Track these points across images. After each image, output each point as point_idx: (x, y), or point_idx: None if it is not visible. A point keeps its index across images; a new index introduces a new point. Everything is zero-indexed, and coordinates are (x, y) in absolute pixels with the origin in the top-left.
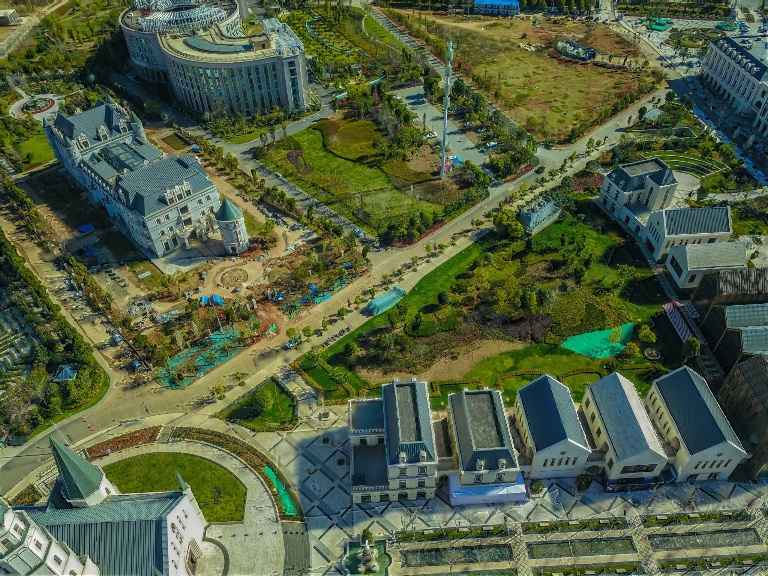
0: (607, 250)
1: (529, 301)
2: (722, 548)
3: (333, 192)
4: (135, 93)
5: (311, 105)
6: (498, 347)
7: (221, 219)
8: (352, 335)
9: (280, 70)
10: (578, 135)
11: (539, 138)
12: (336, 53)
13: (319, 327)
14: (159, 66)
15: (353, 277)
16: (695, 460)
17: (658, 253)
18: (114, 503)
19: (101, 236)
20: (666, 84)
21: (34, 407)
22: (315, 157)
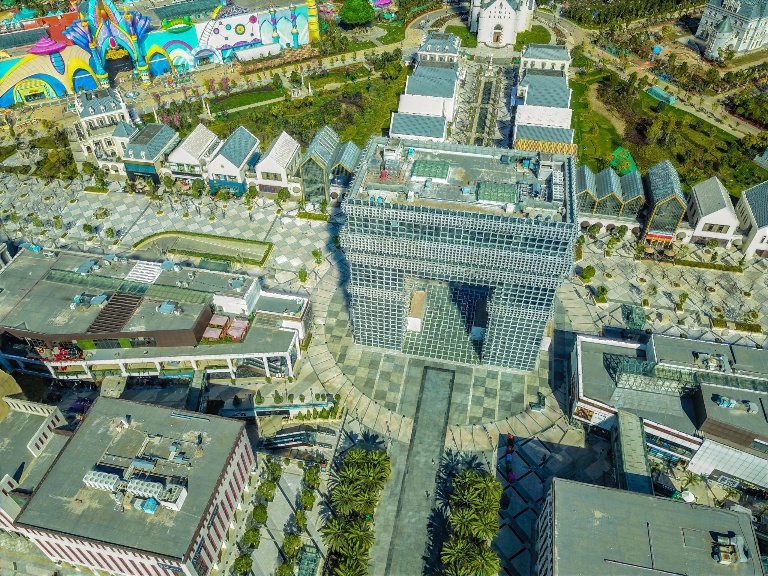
0: None
1: None
2: None
3: None
4: None
5: None
6: (619, 125)
7: None
8: None
9: None
10: None
11: None
12: None
13: None
14: None
15: (686, 90)
16: None
17: None
18: (516, 4)
19: None
20: None
21: None
22: None
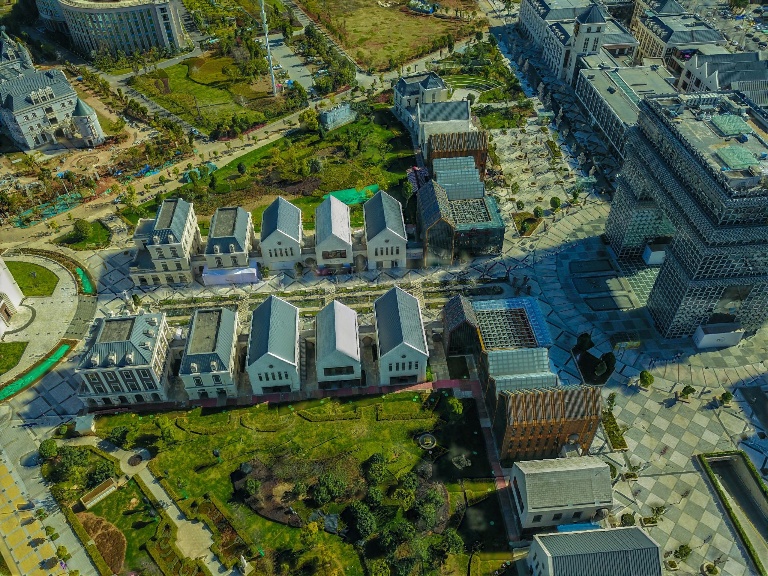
0: (385, 140)
1: (302, 166)
2: None
3: (178, 102)
4: (40, 41)
5: (186, 47)
6: None
7: (76, 115)
8: (167, 194)
9: (154, 16)
10: (397, 65)
11: (365, 68)
12: (220, 10)
13: (144, 190)
14: (61, 18)
15: (181, 160)
16: (372, 246)
17: (419, 139)
18: None
19: None
20: (487, 30)
21: None
22: (177, 83)
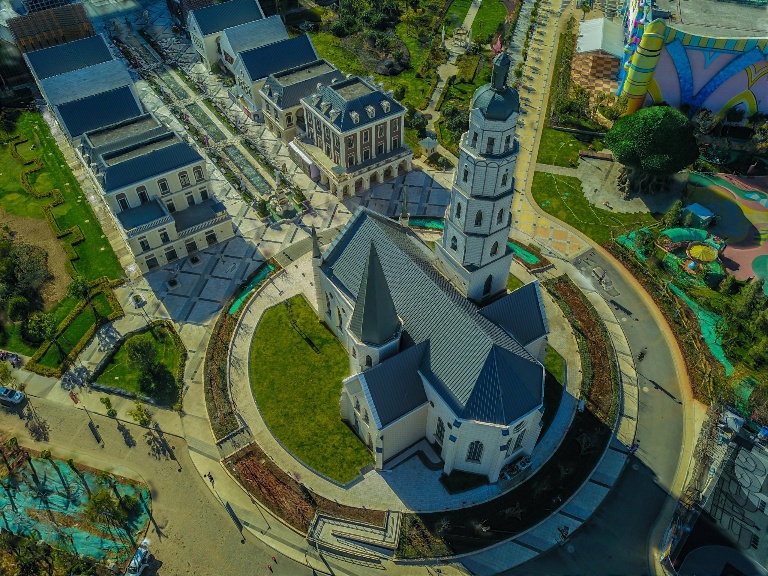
0: None
1: None
2: (174, 77)
3: None
4: None
5: None
6: None
7: None
8: None
9: None
10: None
11: None
12: None
13: None
14: None
15: None
16: None
17: None
18: None
19: None
20: None
21: None
22: None
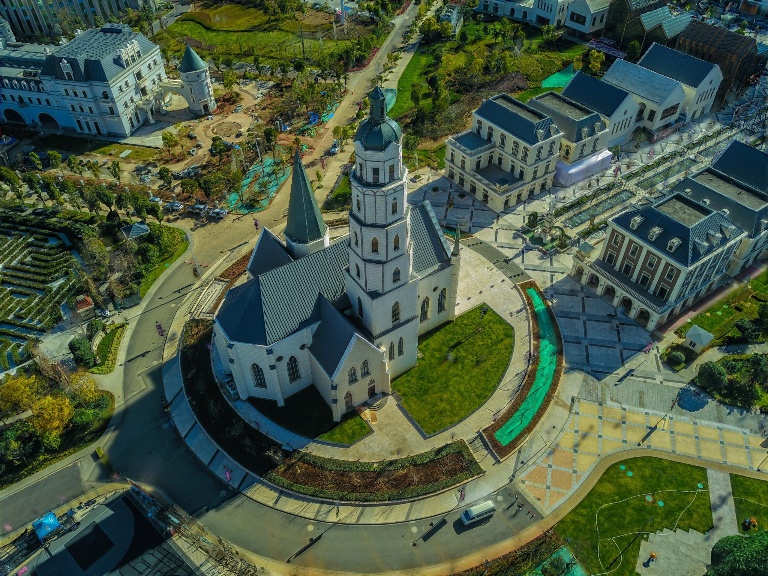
0: None
1: (504, 60)
2: None
3: (265, 44)
4: None
5: None
6: None
7: (191, 70)
8: None
9: None
10: None
11: None
12: None
13: None
14: None
15: (339, 97)
16: (698, 93)
17: (554, 20)
18: None
19: (33, 143)
20: None
21: (119, 274)
22: (208, 37)
